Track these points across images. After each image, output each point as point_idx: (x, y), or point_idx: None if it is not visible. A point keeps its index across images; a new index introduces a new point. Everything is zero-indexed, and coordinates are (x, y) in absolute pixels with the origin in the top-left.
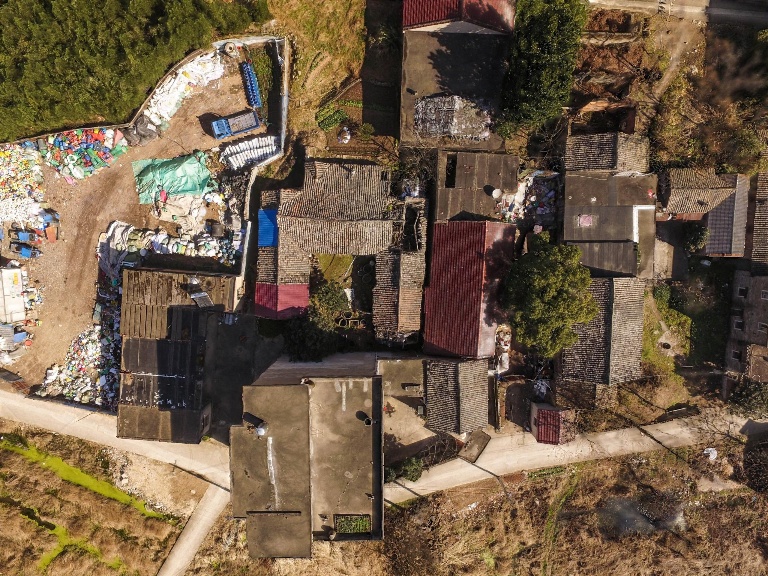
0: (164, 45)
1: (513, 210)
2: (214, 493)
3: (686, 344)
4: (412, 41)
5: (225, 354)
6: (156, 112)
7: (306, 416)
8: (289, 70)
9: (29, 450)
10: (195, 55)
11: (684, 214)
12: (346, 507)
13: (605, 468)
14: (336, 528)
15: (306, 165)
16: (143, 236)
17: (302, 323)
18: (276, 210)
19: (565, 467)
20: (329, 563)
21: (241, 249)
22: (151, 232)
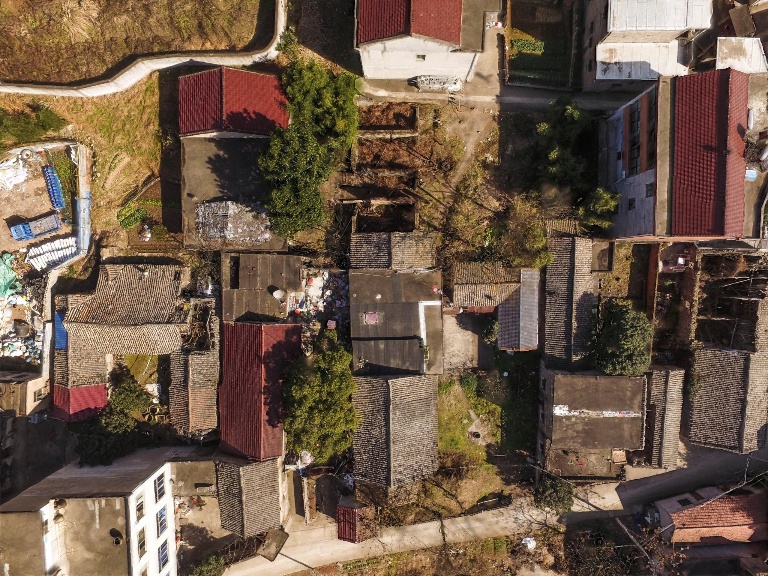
0: None
1: (304, 307)
2: None
3: (497, 433)
4: (190, 147)
5: (36, 451)
6: None
7: (41, 542)
8: (90, 171)
9: None
10: None
11: (475, 307)
12: None
13: (423, 558)
14: None
15: (100, 267)
16: None
17: (93, 426)
18: None
19: (380, 558)
20: None
21: None
22: None
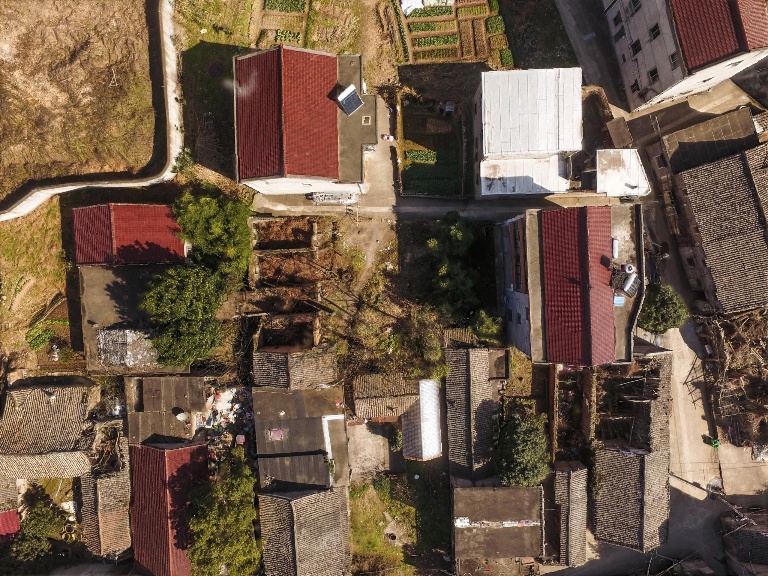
0: None
1: (211, 424)
2: None
3: (412, 533)
4: (88, 275)
5: None
6: None
7: None
8: None
9: None
10: None
11: (379, 418)
12: None
13: None
14: None
15: (7, 393)
16: None
17: (4, 555)
18: None
19: None
20: None
21: None
22: None
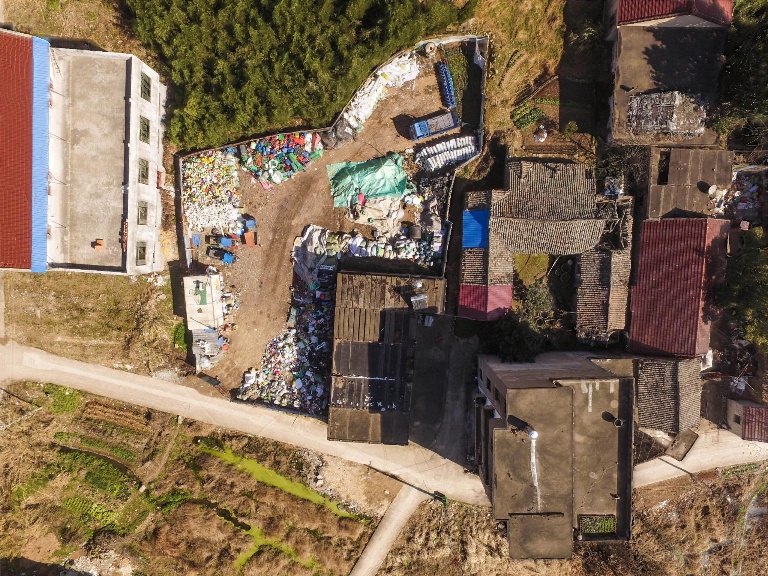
0: (380, 47)
1: (721, 206)
2: (407, 493)
3: None
4: (627, 36)
5: (421, 355)
6: (355, 115)
7: (570, 418)
8: None
9: (225, 453)
10: (395, 56)
11: None
12: (590, 507)
13: None
14: (581, 528)
15: (510, 165)
16: (340, 239)
17: (513, 324)
18: (485, 211)
19: (760, 464)
20: (519, 561)
21: (441, 251)
22: (347, 235)
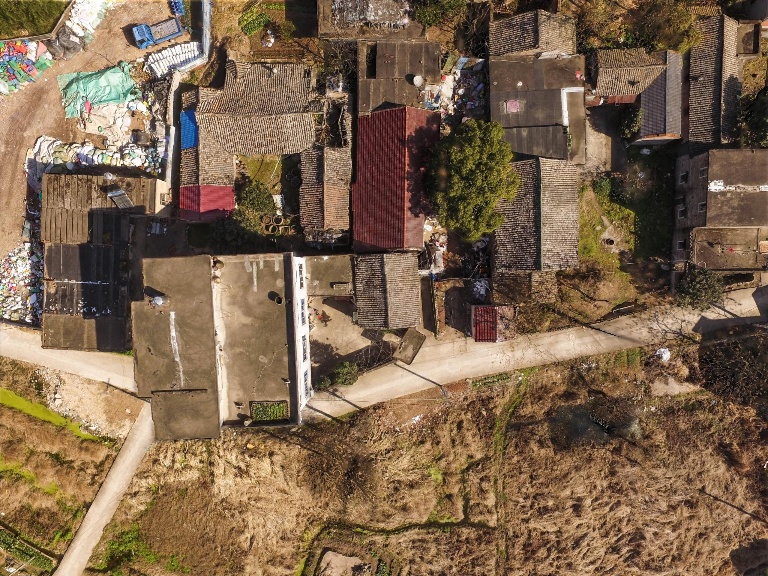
0: None
1: (439, 102)
2: (149, 412)
3: (630, 239)
4: None
5: None
6: (78, 23)
7: (209, 288)
8: None
9: None
10: None
11: (616, 97)
12: (262, 393)
13: (553, 374)
14: (252, 415)
15: (227, 66)
16: (69, 149)
17: None
18: None
19: (511, 374)
20: (271, 483)
21: (166, 156)
22: (77, 145)
